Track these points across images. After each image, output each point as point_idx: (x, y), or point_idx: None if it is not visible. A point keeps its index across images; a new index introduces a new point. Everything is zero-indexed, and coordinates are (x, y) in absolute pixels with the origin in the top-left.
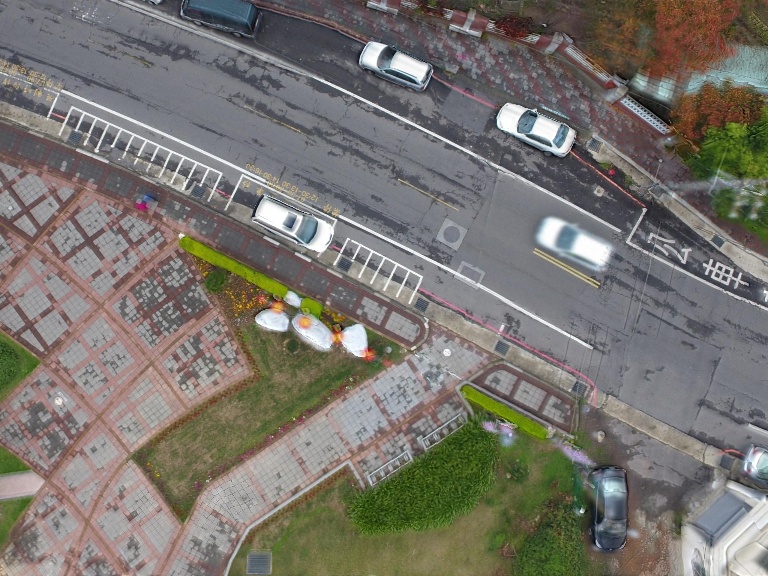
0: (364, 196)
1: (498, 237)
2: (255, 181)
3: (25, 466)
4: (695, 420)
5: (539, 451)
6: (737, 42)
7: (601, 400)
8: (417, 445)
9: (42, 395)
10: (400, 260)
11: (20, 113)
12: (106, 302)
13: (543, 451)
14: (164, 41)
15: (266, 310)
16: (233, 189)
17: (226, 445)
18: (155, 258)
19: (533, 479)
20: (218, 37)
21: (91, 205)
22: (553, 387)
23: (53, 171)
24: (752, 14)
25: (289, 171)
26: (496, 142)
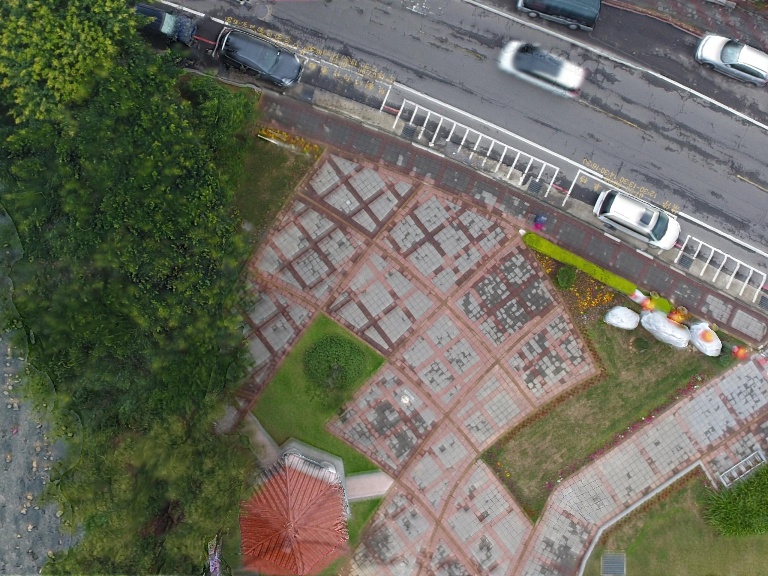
0: (704, 193)
1: None
2: (593, 177)
3: (374, 465)
4: None
5: None
6: None
7: None
8: (767, 445)
9: (389, 393)
10: (743, 258)
11: (352, 105)
12: (449, 299)
13: None
14: (496, 33)
15: (621, 308)
16: (571, 185)
17: (576, 445)
18: (497, 254)
19: None
20: (551, 29)
21: (430, 200)
22: None
23: (390, 165)
24: None
25: (627, 167)
26: None
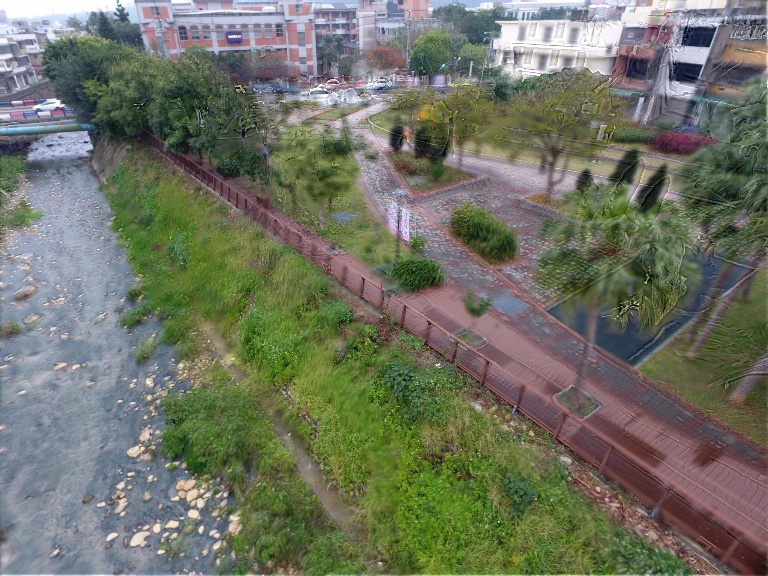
0: None
1: None
2: None
3: None
4: None
5: None
6: None
7: None
8: None
9: None
10: None
11: None
12: None
13: None
14: None
15: None
16: None
17: None
18: (280, 106)
19: None
20: None
21: None
22: None
23: None
24: None
25: None
26: None
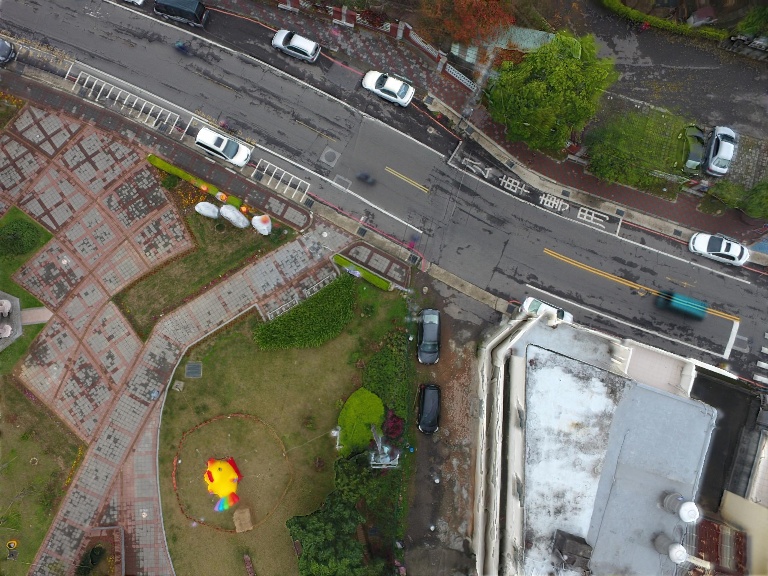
0: (273, 131)
1: (361, 159)
2: (201, 121)
3: (40, 304)
4: (490, 281)
5: (384, 299)
6: (520, 28)
7: (427, 267)
8: (302, 295)
9: (54, 258)
10: (295, 173)
11: (47, 75)
12: (98, 198)
13: (386, 300)
14: (144, 29)
15: (202, 202)
16: (186, 126)
17: (174, 292)
18: (132, 170)
19: (379, 318)
20: (180, 27)
21: (91, 135)
22: (394, 257)
23: (67, 113)
24: (542, 18)
25: (224, 115)
26: (362, 97)
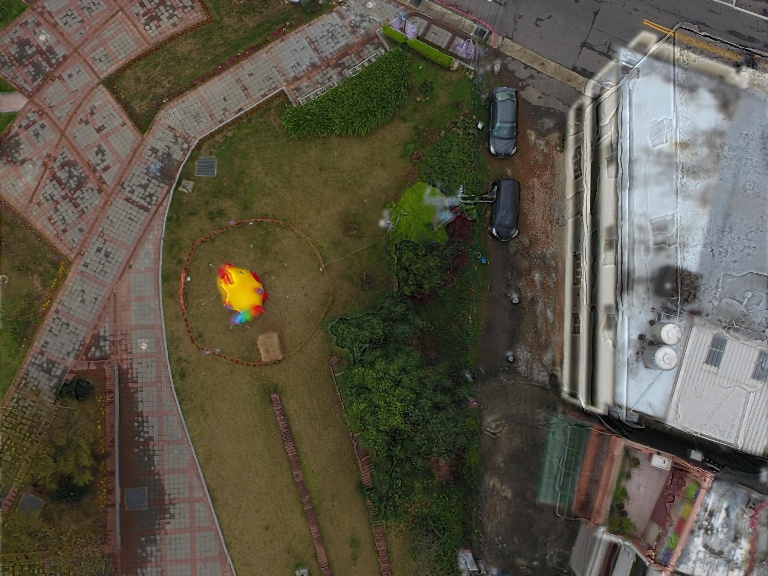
0: None
1: None
2: None
3: (12, 88)
4: (577, 59)
5: (444, 81)
6: None
7: (498, 42)
8: (342, 77)
9: (29, 32)
10: None
11: None
12: None
13: (448, 81)
14: None
15: None
16: None
17: (181, 73)
18: None
19: (439, 103)
20: None
21: None
22: (457, 30)
23: None
24: None
25: None
26: None
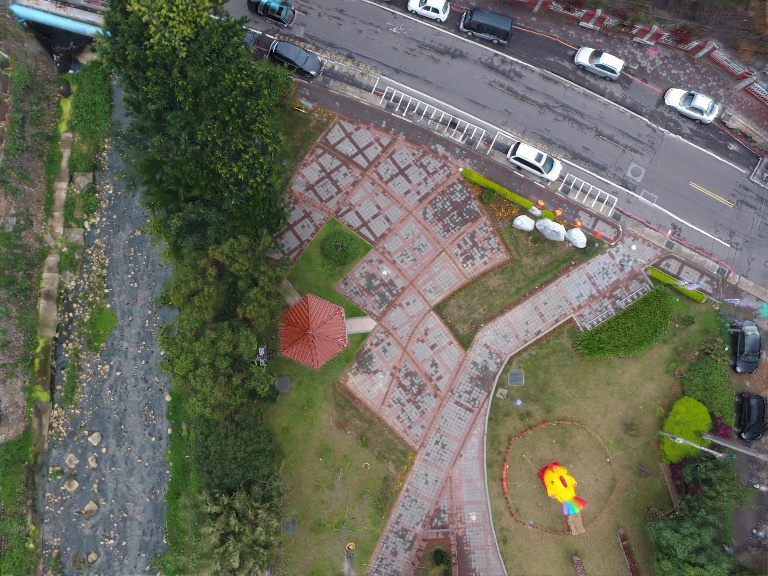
0: (578, 147)
1: (666, 174)
2: (507, 136)
3: (364, 314)
4: None
5: (696, 311)
6: None
7: (735, 279)
8: (616, 306)
9: (374, 269)
10: (602, 188)
11: (354, 90)
12: (414, 210)
13: (699, 311)
14: (446, 45)
15: (522, 215)
16: (492, 141)
17: (493, 303)
18: (444, 183)
19: (693, 329)
20: (481, 44)
21: (402, 149)
22: (705, 270)
23: (377, 127)
24: None
25: (529, 130)
26: (663, 114)
